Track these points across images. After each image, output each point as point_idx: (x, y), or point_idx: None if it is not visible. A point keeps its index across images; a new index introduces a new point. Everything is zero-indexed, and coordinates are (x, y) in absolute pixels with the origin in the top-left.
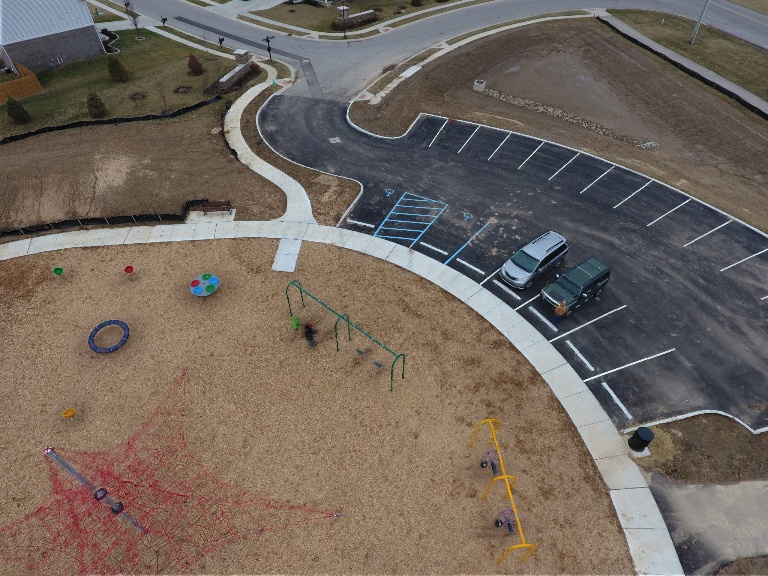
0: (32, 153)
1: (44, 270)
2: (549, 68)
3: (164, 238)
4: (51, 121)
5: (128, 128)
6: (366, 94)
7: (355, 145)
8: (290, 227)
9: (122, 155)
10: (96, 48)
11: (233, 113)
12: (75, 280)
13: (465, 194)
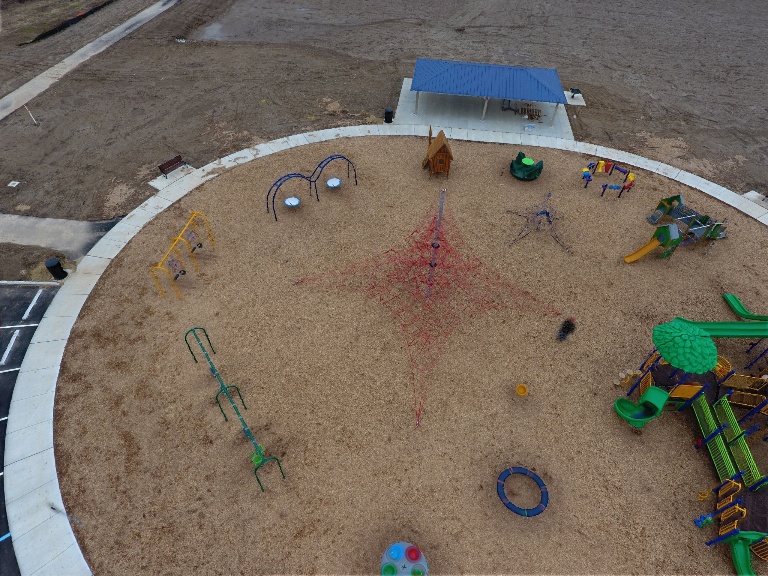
0: None
1: None
2: None
3: None
4: None
5: None
6: None
7: None
8: None
9: None
10: None
11: None
12: None
13: None
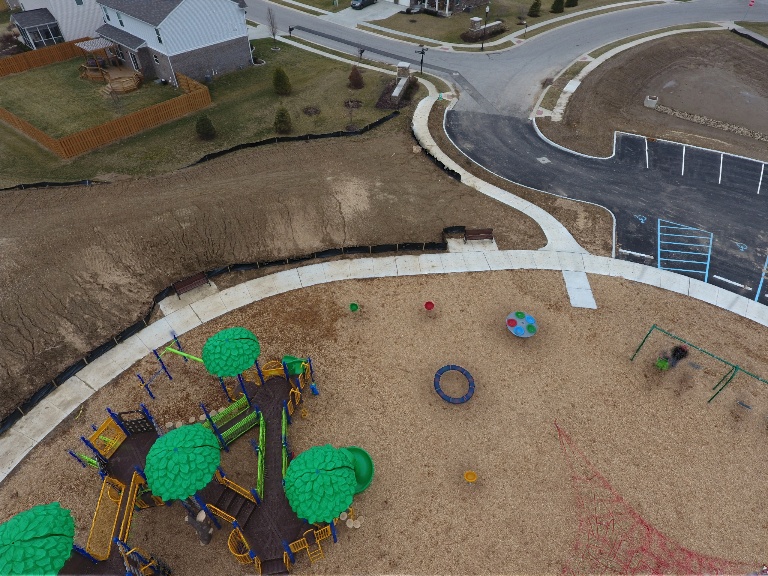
0: (260, 174)
1: (331, 305)
2: (706, 83)
3: (438, 269)
4: (238, 137)
5: (326, 146)
6: (542, 110)
7: (569, 166)
8: (564, 257)
9: (352, 177)
10: (246, 59)
11: (420, 130)
12: (371, 317)
13: (722, 221)
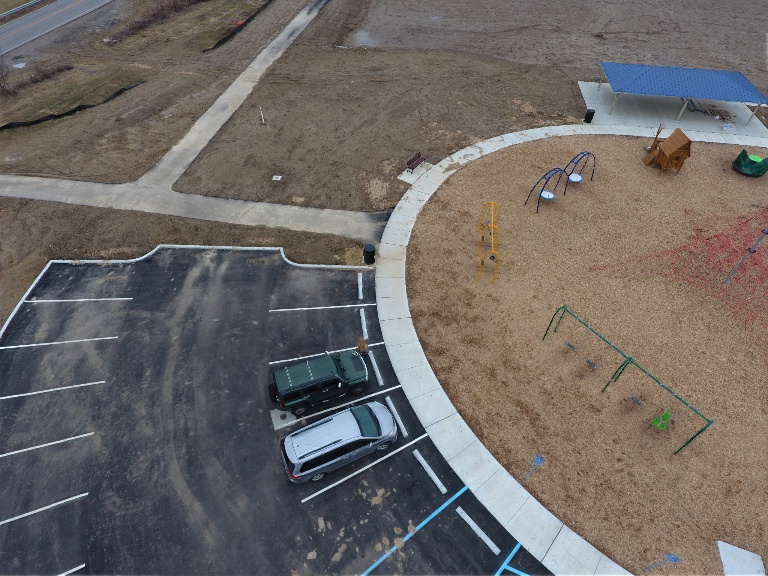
0: None
1: None
2: None
3: None
4: None
5: None
6: None
7: None
8: None
9: None
10: None
11: None
12: None
13: None
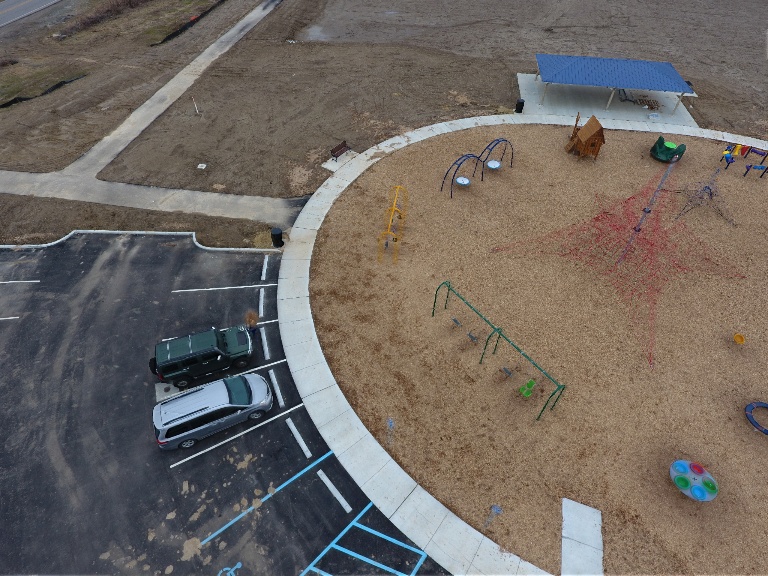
0: None
1: None
2: None
3: None
4: None
5: None
6: None
7: None
8: None
9: None
10: None
11: None
12: None
13: None
